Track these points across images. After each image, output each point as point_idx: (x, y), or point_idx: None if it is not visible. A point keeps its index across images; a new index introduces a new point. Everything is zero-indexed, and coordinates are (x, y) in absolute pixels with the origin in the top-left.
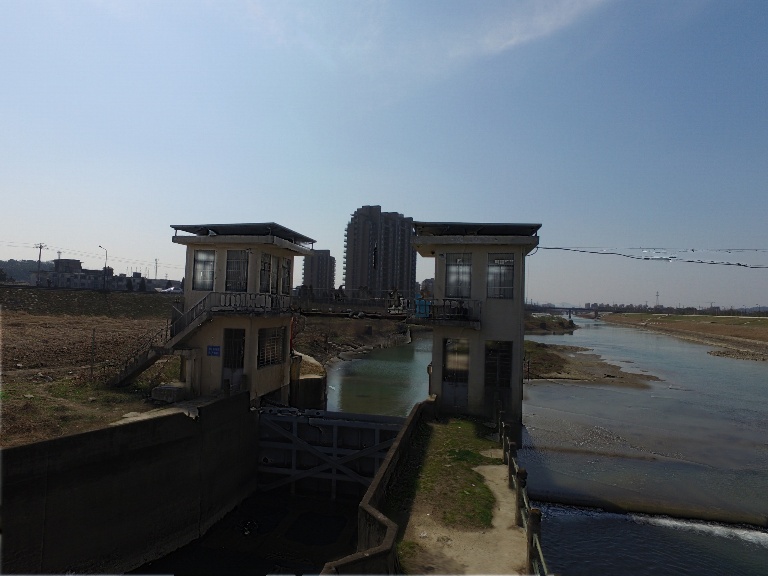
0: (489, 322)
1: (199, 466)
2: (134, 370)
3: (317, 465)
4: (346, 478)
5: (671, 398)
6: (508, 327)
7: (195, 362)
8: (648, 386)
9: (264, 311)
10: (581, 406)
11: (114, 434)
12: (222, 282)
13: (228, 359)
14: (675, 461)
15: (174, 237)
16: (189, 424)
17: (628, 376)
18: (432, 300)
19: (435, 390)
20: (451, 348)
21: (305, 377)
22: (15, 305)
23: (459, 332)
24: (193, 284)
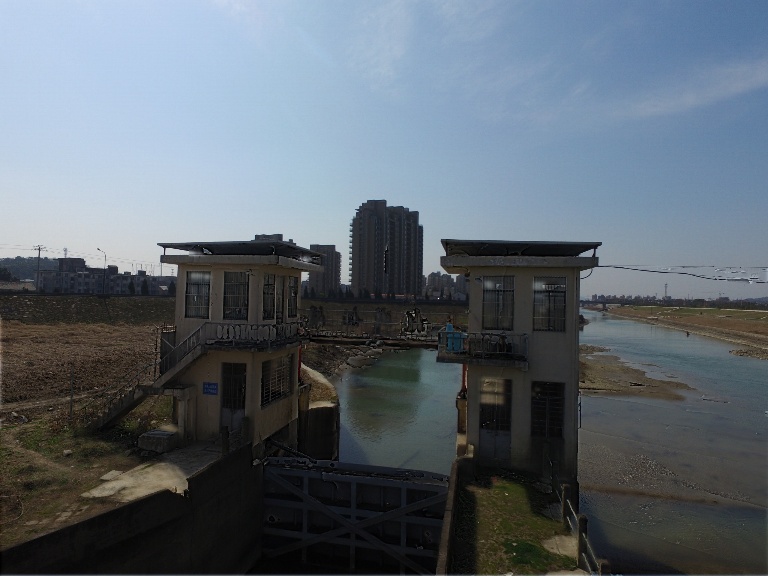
0: (536, 359)
1: (190, 551)
2: (119, 412)
3: (332, 528)
4: (367, 545)
5: (709, 413)
6: (559, 365)
7: (189, 402)
8: (680, 397)
9: (268, 344)
10: (614, 425)
11: (76, 533)
12: (219, 309)
13: (227, 398)
14: (740, 505)
15: (163, 257)
16: (176, 502)
17: (655, 384)
18: (468, 334)
19: (471, 439)
20: (490, 389)
21: (315, 406)
22: (9, 313)
23: (500, 371)
24: (186, 311)
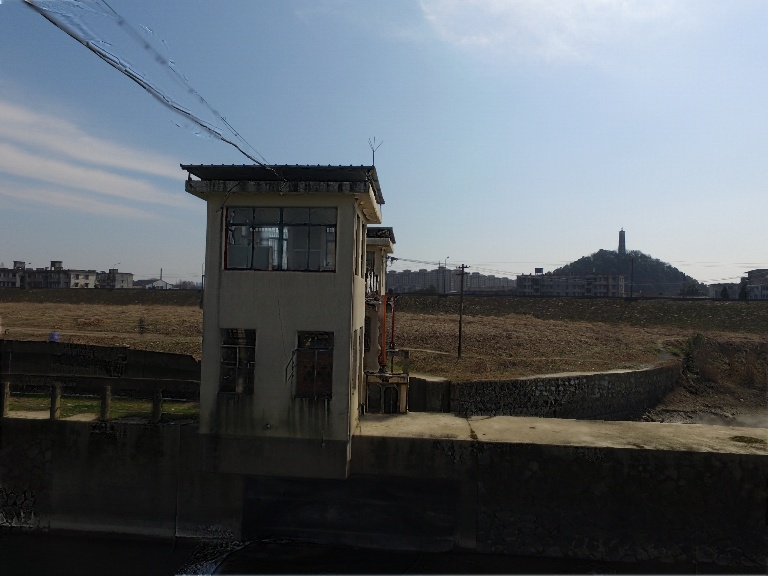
0: None
1: None
2: None
3: None
4: None
5: None
6: None
7: None
8: None
9: None
10: None
11: (163, 356)
12: None
13: None
14: None
15: None
16: (194, 363)
17: None
18: None
19: None
20: None
21: (424, 377)
22: (540, 311)
23: None
24: None
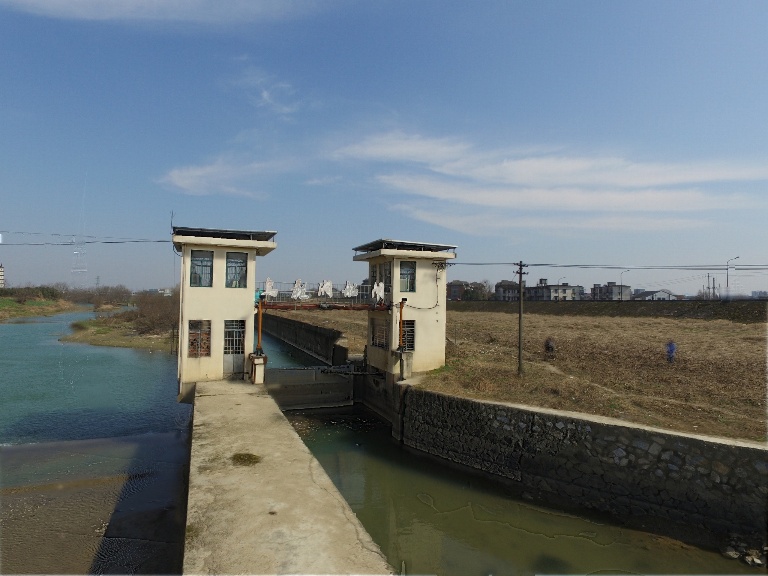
0: None
1: None
2: None
3: None
4: None
5: None
6: None
7: None
8: None
9: None
10: None
11: None
12: None
13: None
14: None
15: None
16: None
17: None
18: None
19: None
20: None
21: (409, 380)
22: None
23: None
24: None
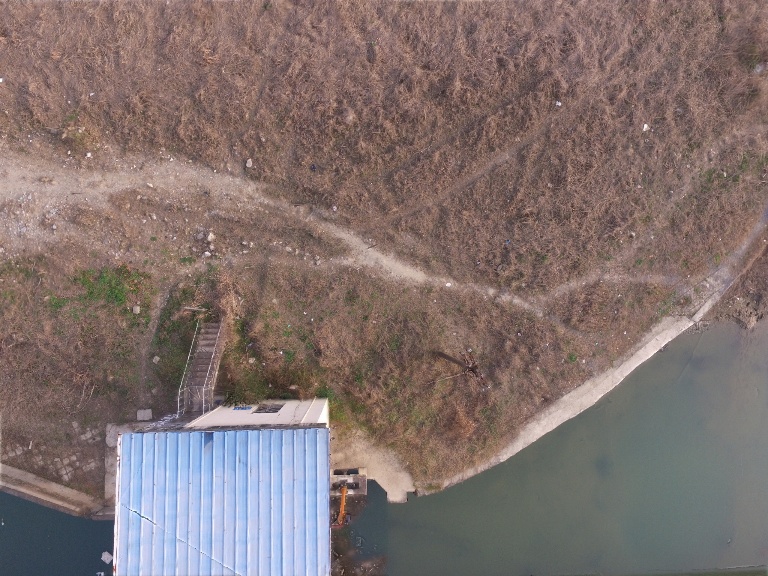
0: None
1: None
2: None
3: None
4: None
5: None
6: None
7: None
8: None
9: None
10: None
11: None
12: None
13: None
14: None
15: None
16: None
17: None
18: None
19: None
20: None
21: (385, 480)
22: None
23: None
24: None
